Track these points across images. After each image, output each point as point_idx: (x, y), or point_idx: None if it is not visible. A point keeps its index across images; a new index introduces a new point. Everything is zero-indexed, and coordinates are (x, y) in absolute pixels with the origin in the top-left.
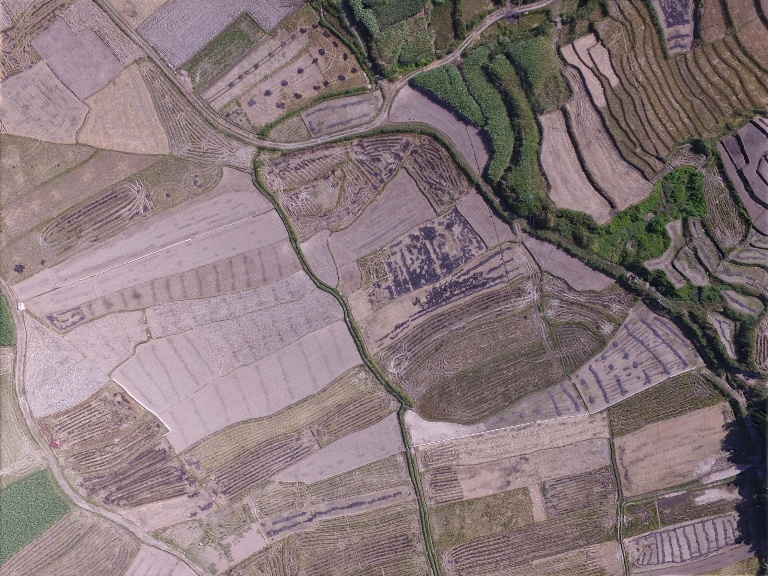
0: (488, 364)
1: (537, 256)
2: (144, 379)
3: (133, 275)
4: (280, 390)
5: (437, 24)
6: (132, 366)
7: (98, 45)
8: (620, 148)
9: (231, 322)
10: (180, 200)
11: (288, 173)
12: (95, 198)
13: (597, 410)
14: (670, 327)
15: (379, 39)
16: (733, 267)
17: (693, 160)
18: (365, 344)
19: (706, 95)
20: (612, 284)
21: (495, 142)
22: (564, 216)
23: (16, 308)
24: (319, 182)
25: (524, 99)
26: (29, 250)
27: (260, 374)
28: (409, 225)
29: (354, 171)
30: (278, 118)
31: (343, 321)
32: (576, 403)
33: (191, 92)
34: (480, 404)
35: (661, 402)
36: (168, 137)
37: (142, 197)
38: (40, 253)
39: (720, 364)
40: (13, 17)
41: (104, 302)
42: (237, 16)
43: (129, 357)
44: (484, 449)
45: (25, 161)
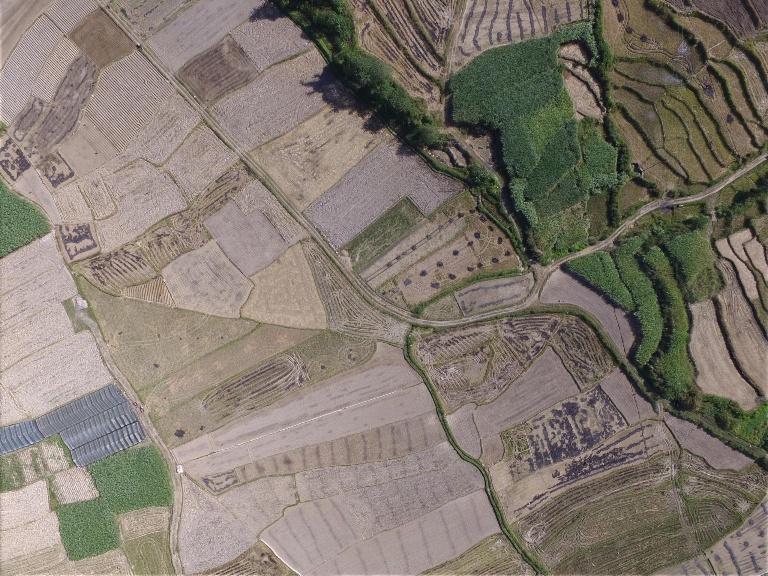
0: (624, 537)
1: (677, 434)
2: (290, 540)
3: (286, 442)
4: (419, 555)
5: (592, 212)
6: (280, 527)
7: (265, 226)
8: None
9: (376, 488)
10: (334, 372)
11: (438, 349)
12: (254, 369)
13: None
14: None
15: (537, 229)
16: None
17: None
18: (504, 513)
19: None
20: (751, 464)
21: (644, 328)
22: (709, 401)
23: (175, 471)
24: (468, 358)
25: (676, 288)
26: (190, 416)
27: (401, 539)
28: (553, 401)
29: (502, 348)
30: (432, 297)
31: (483, 490)
32: None
33: (350, 271)
34: (614, 575)
35: None
36: (326, 313)
37: (298, 369)
38: (200, 419)
39: None
40: (188, 199)
41: (257, 466)
42: (398, 200)
43: (278, 519)
44: None
45: (191, 333)
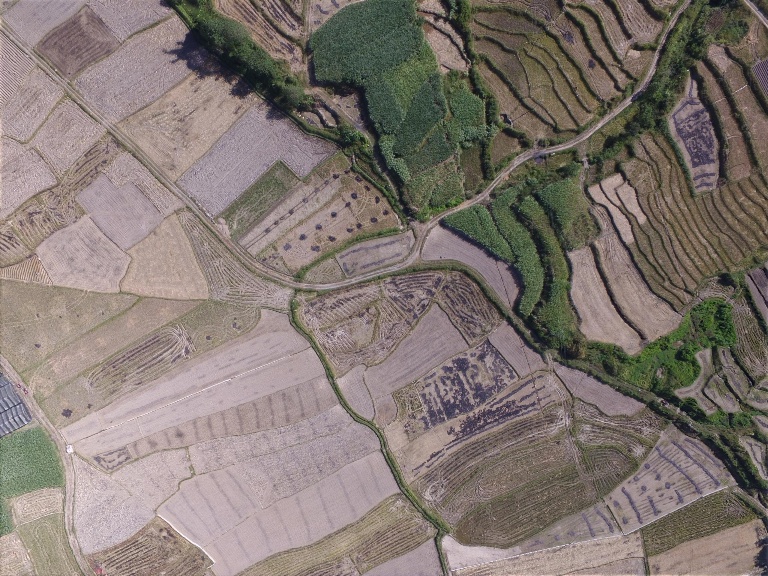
0: (522, 489)
1: (568, 383)
2: (188, 514)
3: (176, 415)
4: (320, 520)
5: (466, 166)
6: (177, 502)
7: (139, 198)
8: (649, 282)
9: (271, 456)
10: (220, 342)
11: (324, 312)
12: (138, 343)
13: (631, 531)
14: (701, 448)
15: (410, 185)
16: (763, 394)
17: (721, 292)
18: (402, 473)
19: (733, 231)
20: (643, 408)
21: (525, 279)
22: (595, 348)
23: (65, 451)
24: (354, 320)
25: (553, 237)
26: (76, 395)
27: (300, 505)
28: (442, 357)
29: (388, 308)
30: (313, 260)
31: (380, 452)
32: (610, 524)
33: (229, 239)
34: (515, 528)
35: (694, 521)
36: (207, 282)
37: (183, 340)
38: (87, 397)
39: (752, 484)
40: (57, 175)
41: (149, 442)
42: (272, 165)
43: (174, 493)
44: (520, 571)
45: (71, 311)
